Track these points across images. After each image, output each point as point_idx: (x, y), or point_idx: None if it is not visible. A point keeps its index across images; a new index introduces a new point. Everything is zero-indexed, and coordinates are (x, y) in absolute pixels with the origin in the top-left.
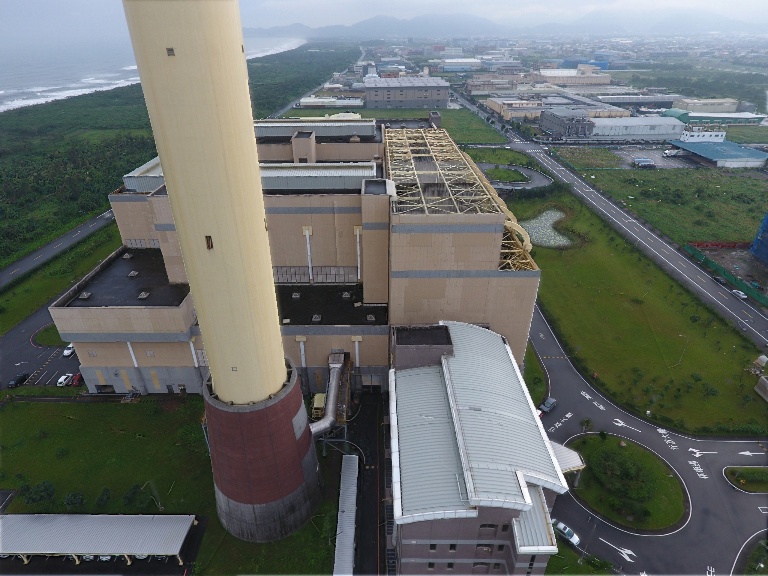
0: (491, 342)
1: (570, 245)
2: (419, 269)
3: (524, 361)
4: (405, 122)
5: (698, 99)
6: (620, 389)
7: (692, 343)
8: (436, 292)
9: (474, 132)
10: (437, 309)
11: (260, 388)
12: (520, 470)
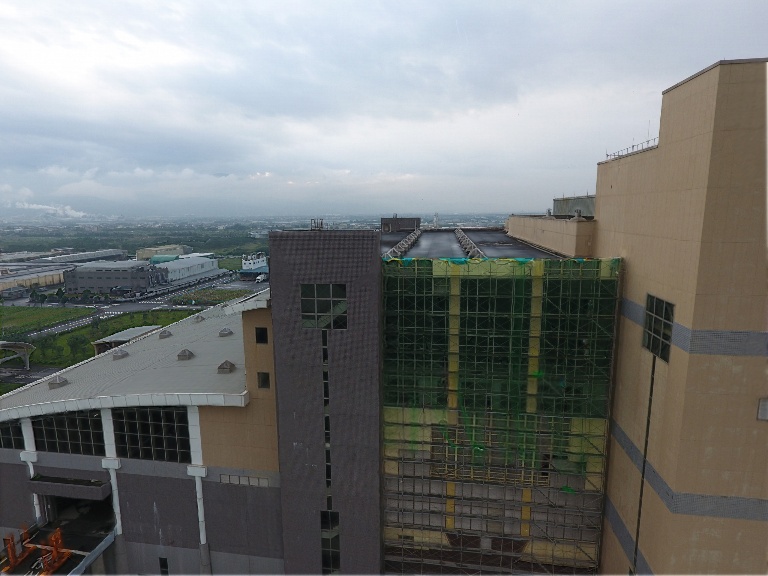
0: None
1: None
2: None
3: None
4: None
5: (156, 247)
6: None
7: None
8: None
9: (1, 315)
10: None
11: None
12: None
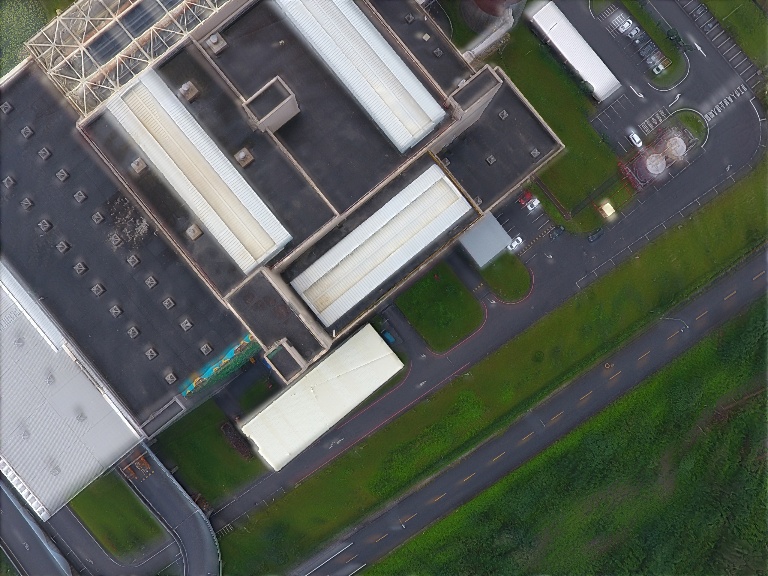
0: None
1: None
2: None
3: None
4: None
5: None
6: None
7: None
8: None
9: None
10: None
11: None
12: None
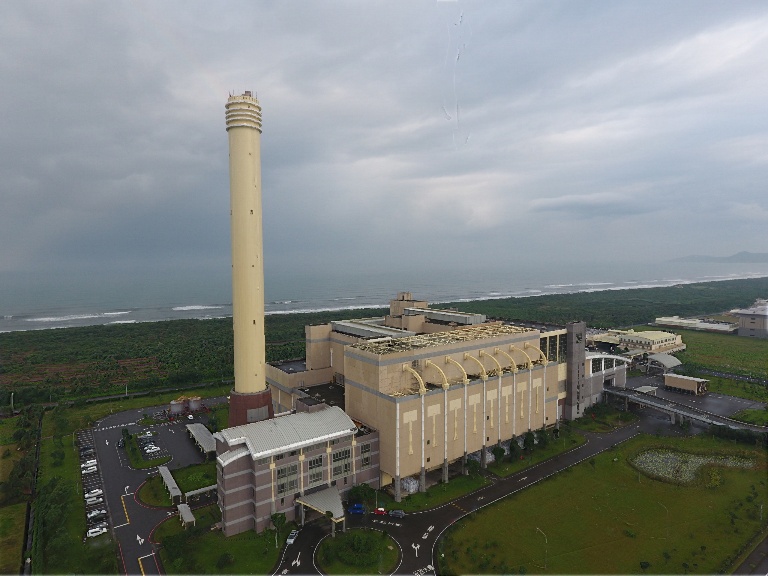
0: (340, 423)
1: (670, 479)
2: (353, 380)
3: (429, 493)
4: (558, 327)
5: None
6: (458, 541)
7: (601, 575)
8: (359, 398)
9: None
10: (360, 410)
11: (240, 387)
12: (247, 438)
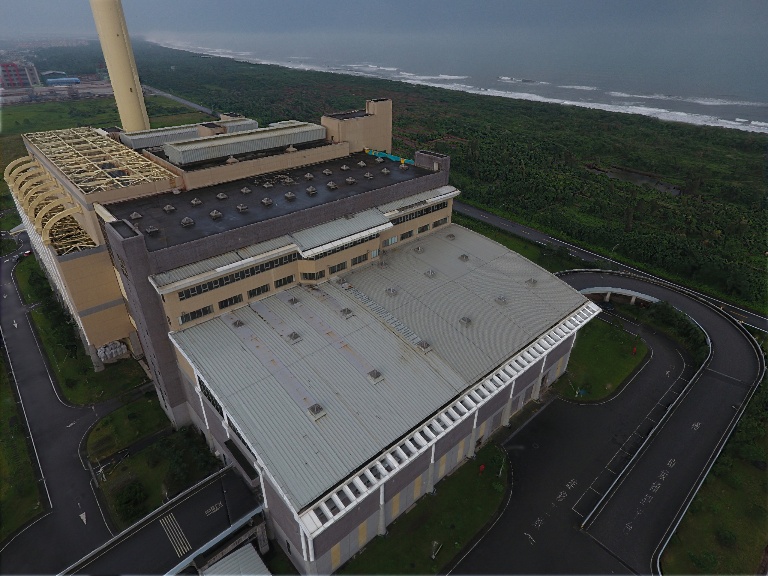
0: None
1: None
2: None
3: None
4: None
5: None
6: None
7: None
8: None
9: None
10: None
11: None
12: None
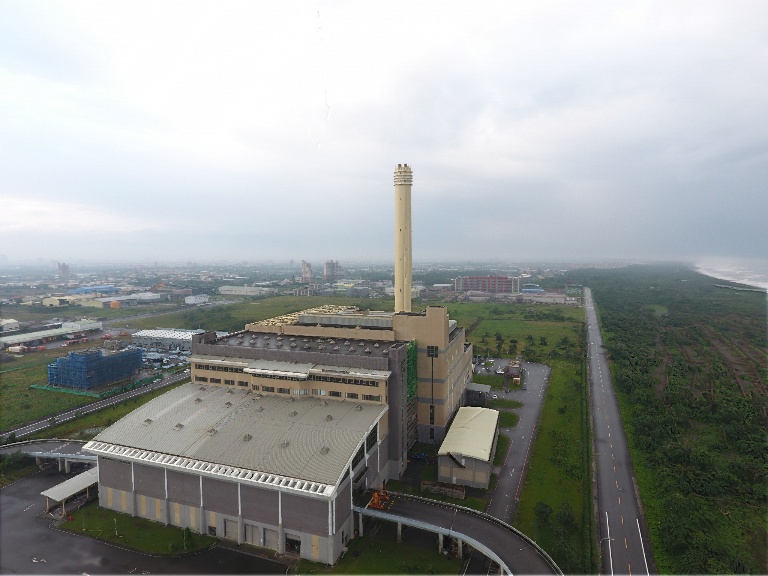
0: None
1: None
2: None
3: None
4: None
5: None
6: None
7: None
8: None
9: None
10: None
11: None
12: None
